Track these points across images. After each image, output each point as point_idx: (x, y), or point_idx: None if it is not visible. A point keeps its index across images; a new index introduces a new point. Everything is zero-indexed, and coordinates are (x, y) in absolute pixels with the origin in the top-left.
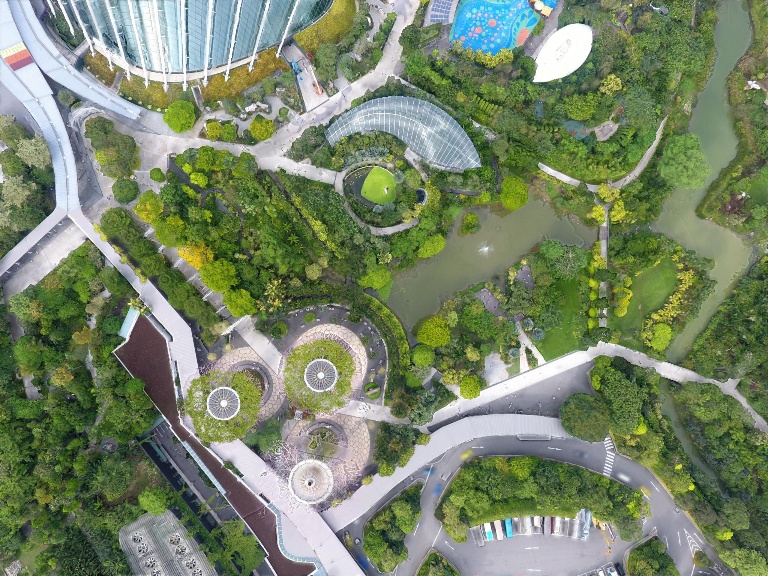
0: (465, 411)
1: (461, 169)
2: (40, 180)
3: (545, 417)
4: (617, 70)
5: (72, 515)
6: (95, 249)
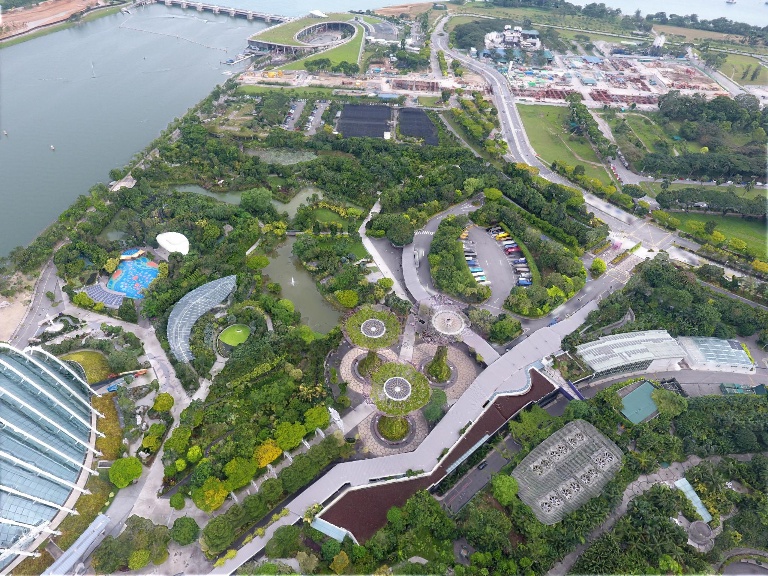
0: (404, 292)
1: (235, 289)
2: None
3: (403, 253)
4: None
5: None
6: None
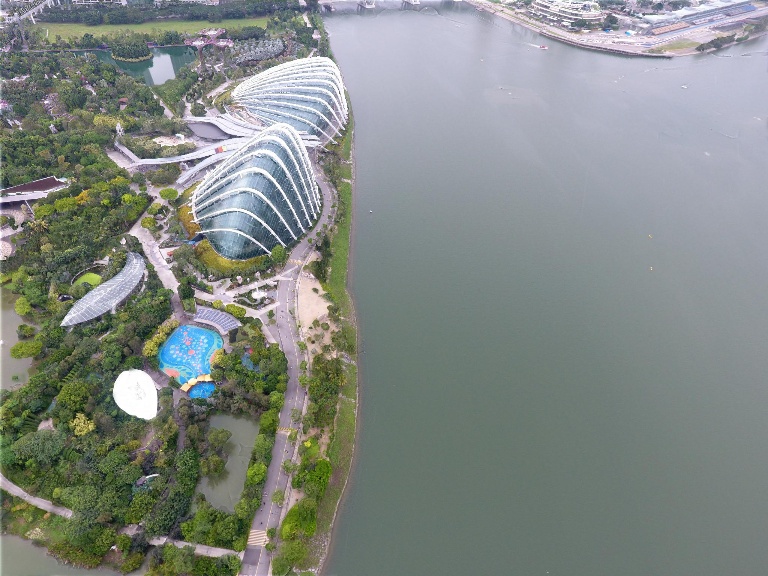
0: None
1: None
2: None
3: None
4: (101, 438)
5: None
6: None
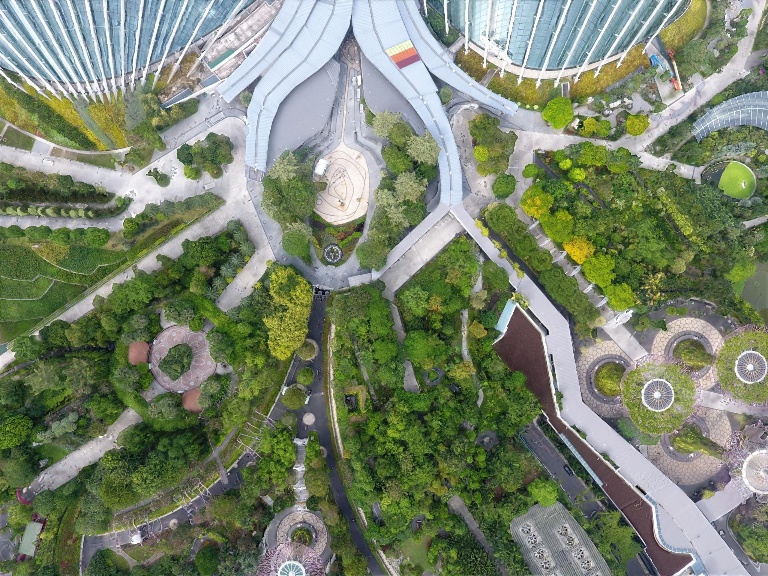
0: None
1: None
2: (424, 176)
3: None
4: None
5: (451, 507)
6: (474, 244)
